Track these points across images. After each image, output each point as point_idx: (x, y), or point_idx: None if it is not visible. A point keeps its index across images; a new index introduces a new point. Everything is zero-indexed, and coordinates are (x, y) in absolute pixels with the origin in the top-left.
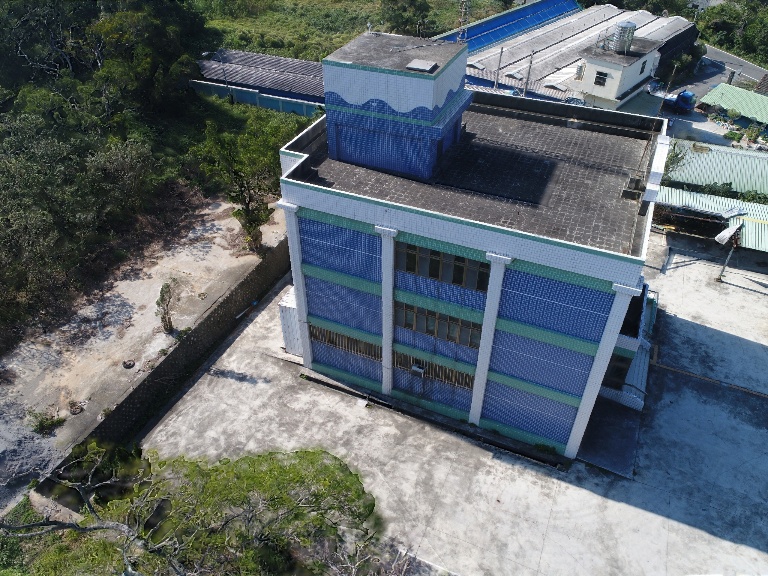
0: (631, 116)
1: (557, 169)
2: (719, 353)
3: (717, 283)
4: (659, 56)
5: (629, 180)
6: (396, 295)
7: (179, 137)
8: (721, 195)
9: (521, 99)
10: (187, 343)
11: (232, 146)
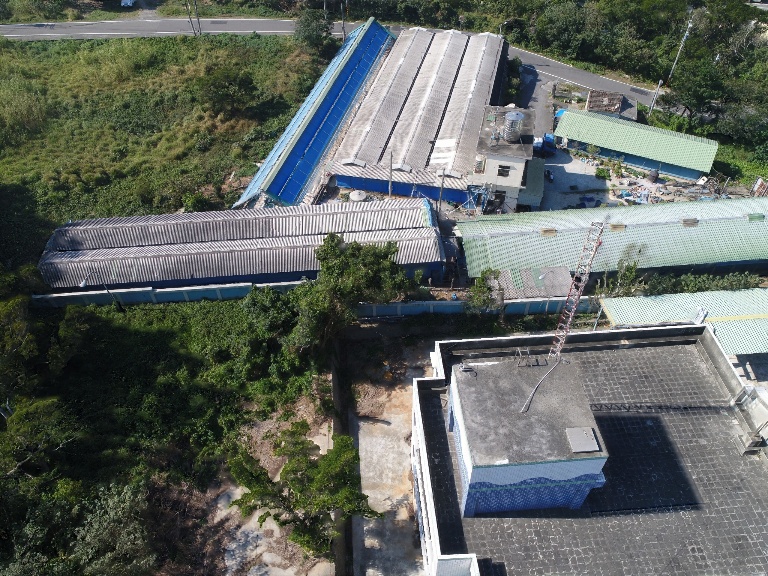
0: (677, 329)
1: (666, 432)
2: None
3: None
4: None
5: (750, 443)
6: None
7: (109, 410)
8: (671, 289)
9: (572, 336)
10: None
11: (253, 460)
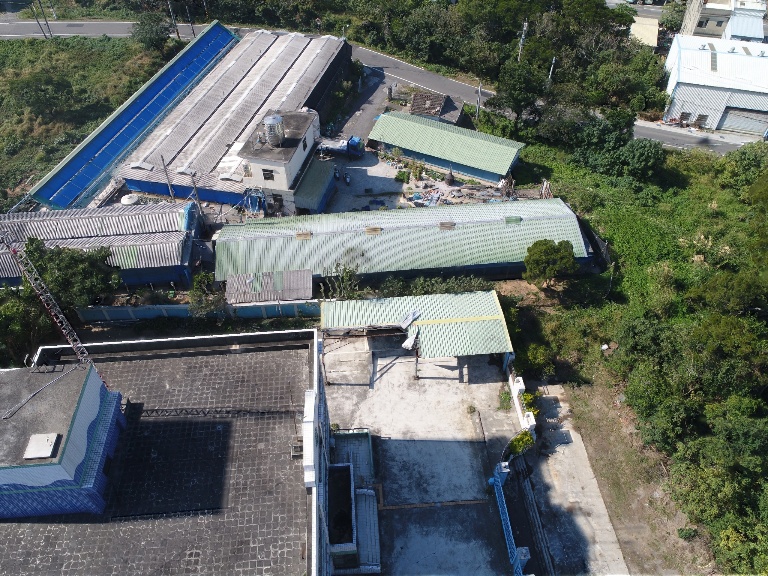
0: (285, 334)
1: (230, 436)
2: (429, 469)
3: (416, 382)
4: (317, 117)
5: (293, 447)
6: None
7: None
8: (398, 292)
9: (178, 341)
10: None
11: None
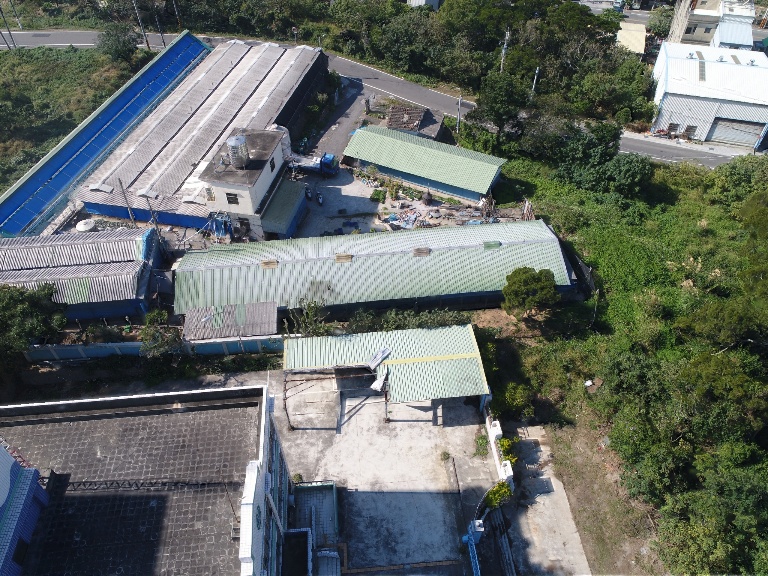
0: (231, 391)
1: (164, 514)
2: (398, 525)
3: (386, 425)
4: (287, 134)
5: None
6: None
7: None
8: (367, 327)
9: (111, 401)
10: None
11: None
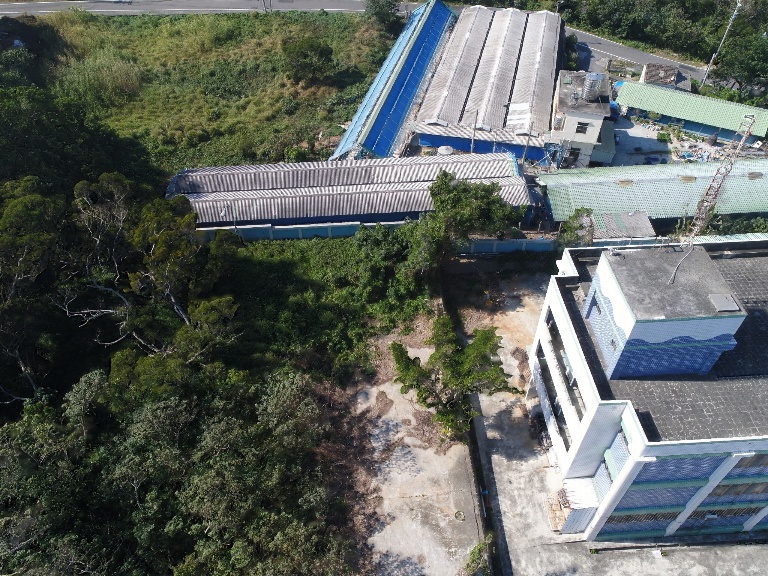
0: None
1: None
2: None
3: None
4: None
5: None
6: (720, 483)
7: (252, 322)
8: (744, 230)
9: None
10: (491, 575)
11: None
